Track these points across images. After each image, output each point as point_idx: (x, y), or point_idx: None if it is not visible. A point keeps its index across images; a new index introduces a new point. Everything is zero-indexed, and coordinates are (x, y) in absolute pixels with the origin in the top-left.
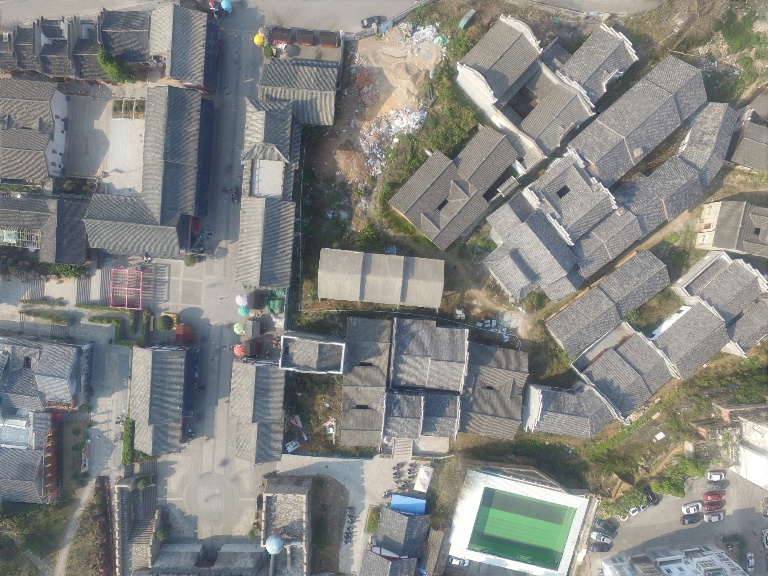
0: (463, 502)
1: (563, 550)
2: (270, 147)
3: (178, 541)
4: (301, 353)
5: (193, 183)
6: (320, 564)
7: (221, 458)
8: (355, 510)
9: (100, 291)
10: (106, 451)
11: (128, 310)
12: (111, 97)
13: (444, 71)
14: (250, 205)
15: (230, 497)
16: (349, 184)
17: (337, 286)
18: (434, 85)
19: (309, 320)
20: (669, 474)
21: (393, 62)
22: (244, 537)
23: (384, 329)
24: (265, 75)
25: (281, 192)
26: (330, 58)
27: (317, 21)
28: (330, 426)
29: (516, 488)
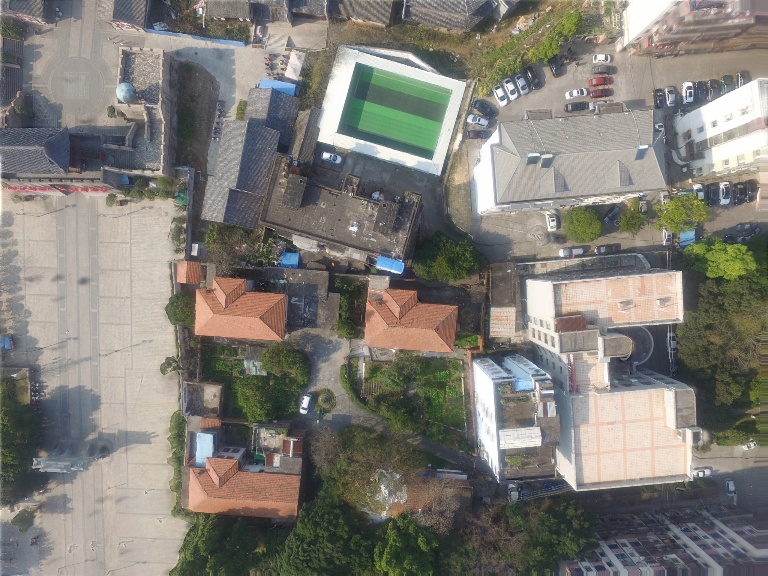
0: (333, 82)
1: (438, 139)
2: None
3: None
4: None
5: None
6: (186, 159)
7: (88, 41)
8: (225, 105)
9: None
10: None
11: None
12: None
13: None
14: None
15: (96, 84)
16: None
17: None
18: None
19: None
20: (546, 37)
21: None
22: (109, 128)
23: None
24: None
25: None
26: None
27: None
28: (200, 8)
29: (388, 66)
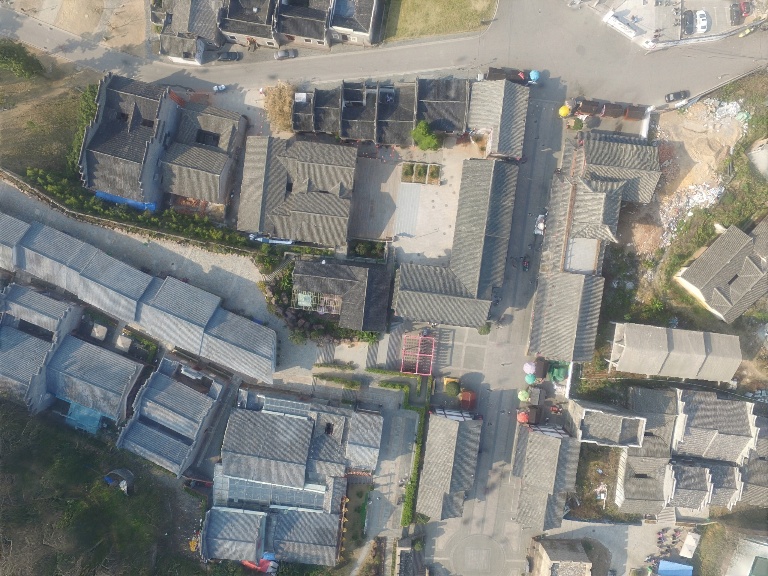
0: (733, 570)
1: None
2: (602, 227)
3: None
4: (600, 426)
5: (504, 255)
6: None
7: (491, 520)
8: (616, 573)
9: (387, 355)
10: (386, 513)
11: (419, 376)
12: (398, 160)
13: (742, 147)
14: (562, 280)
15: (497, 558)
16: (638, 255)
17: (640, 361)
18: (734, 161)
19: (589, 388)
20: None
21: (694, 137)
22: None
23: (669, 400)
24: (588, 152)
25: (593, 268)
26: (630, 130)
27: (619, 93)
28: (601, 492)
29: None
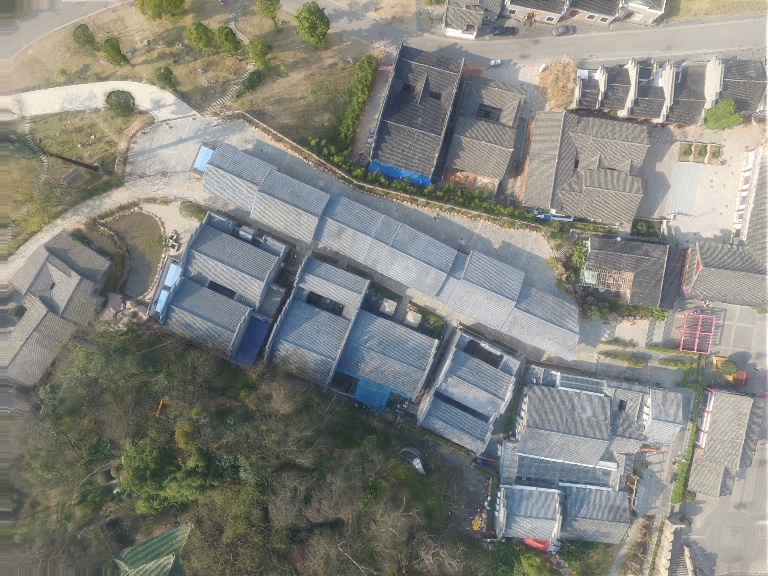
0: None
1: None
2: None
3: None
4: None
5: None
6: None
7: (748, 498)
8: None
9: (663, 333)
10: (656, 491)
11: (698, 354)
12: (672, 140)
13: None
14: None
15: (751, 536)
16: None
17: None
18: None
19: None
20: None
21: None
22: (759, 574)
23: None
24: None
25: None
26: None
27: None
28: None
29: None
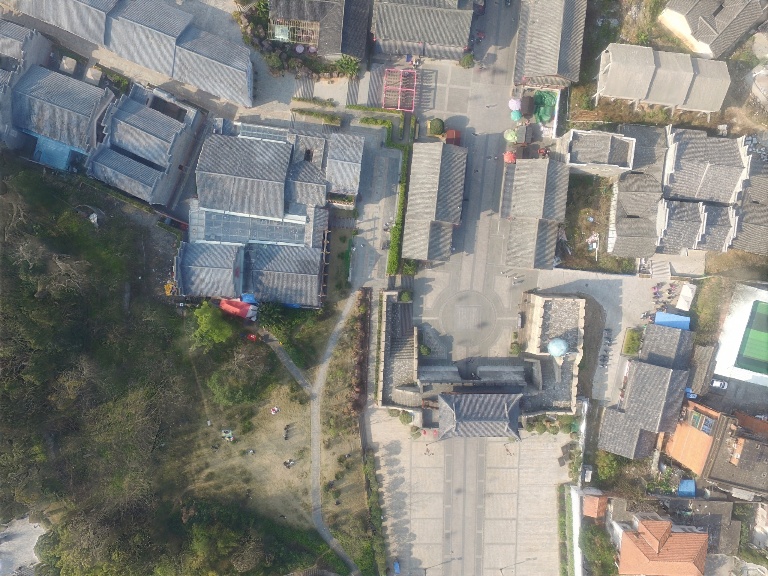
0: (731, 317)
1: None
2: None
3: (431, 363)
4: (588, 150)
5: None
6: None
7: (480, 275)
8: (612, 332)
9: (368, 95)
10: (370, 261)
11: (401, 111)
12: None
13: None
14: None
15: (488, 316)
16: None
17: (627, 80)
18: None
19: None
20: None
21: None
22: (500, 359)
23: (658, 136)
24: None
25: None
26: None
27: None
28: (593, 241)
29: None
